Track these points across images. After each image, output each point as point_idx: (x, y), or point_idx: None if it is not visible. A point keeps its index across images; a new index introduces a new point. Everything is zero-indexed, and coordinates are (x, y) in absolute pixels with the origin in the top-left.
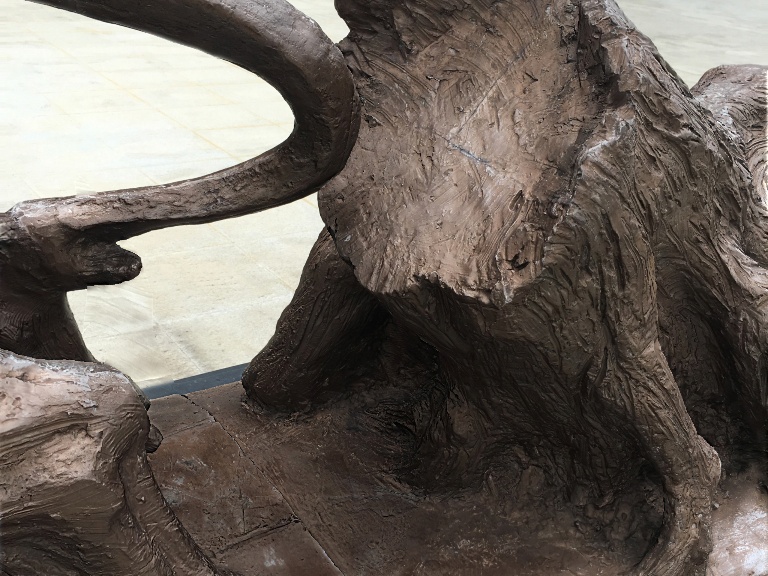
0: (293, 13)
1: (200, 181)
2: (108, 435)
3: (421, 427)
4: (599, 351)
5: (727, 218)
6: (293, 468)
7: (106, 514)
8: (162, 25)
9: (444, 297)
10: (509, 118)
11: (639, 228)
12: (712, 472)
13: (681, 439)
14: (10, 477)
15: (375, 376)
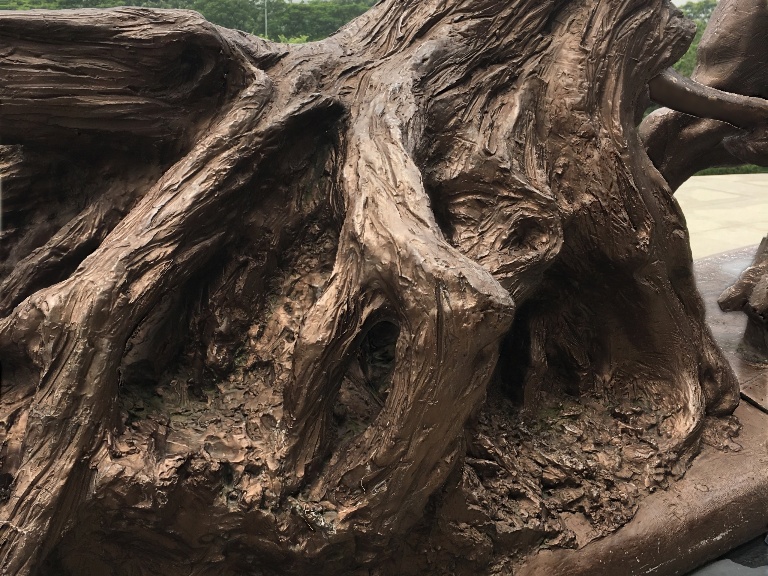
0: None
1: None
2: None
3: None
4: None
5: None
6: None
7: None
8: None
9: None
10: None
11: None
12: None
13: None
14: None
15: None
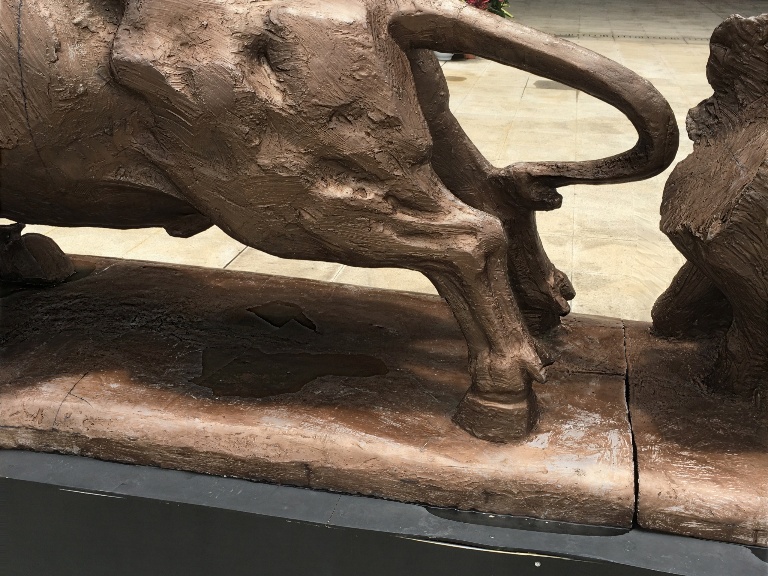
0: (633, 77)
1: (595, 161)
2: (483, 241)
3: None
4: None
5: None
6: (647, 360)
7: (474, 272)
8: (562, 79)
9: None
10: (767, 145)
11: None
12: None
13: None
14: (443, 243)
15: None
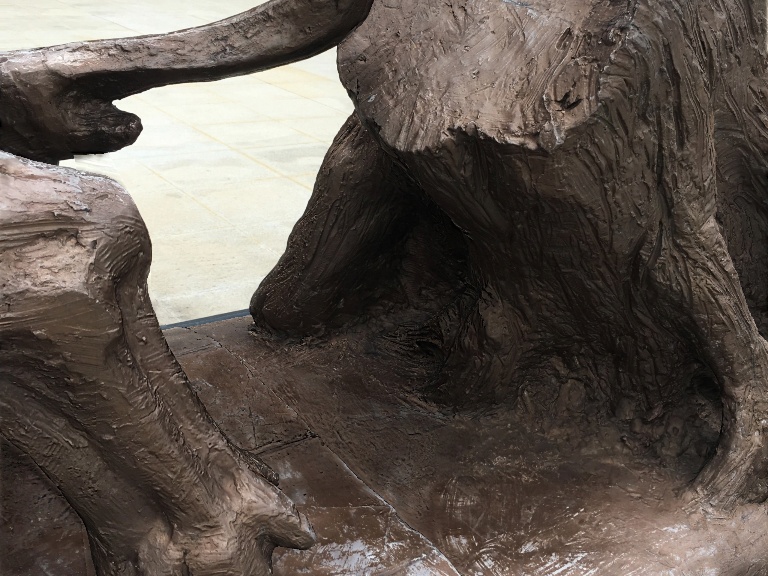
0: None
1: (206, 27)
2: (103, 246)
3: (449, 337)
4: (654, 224)
5: None
6: (307, 389)
7: (100, 340)
8: None
9: (482, 155)
10: None
11: (701, 74)
12: None
13: (743, 332)
14: None
15: (394, 298)
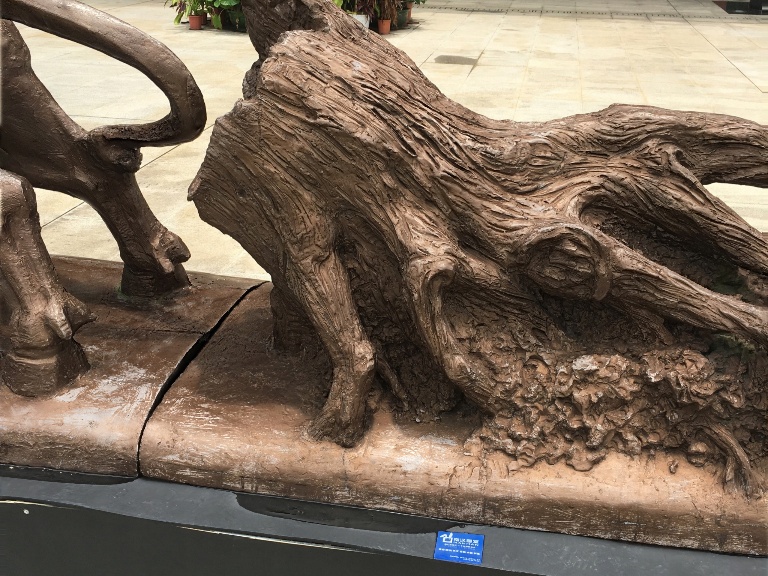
0: (146, 39)
1: None
2: (1, 200)
3: None
4: (278, 253)
5: (419, 197)
6: None
7: None
8: (83, 41)
9: None
10: None
11: (277, 174)
12: (357, 367)
13: (331, 332)
14: None
15: None
